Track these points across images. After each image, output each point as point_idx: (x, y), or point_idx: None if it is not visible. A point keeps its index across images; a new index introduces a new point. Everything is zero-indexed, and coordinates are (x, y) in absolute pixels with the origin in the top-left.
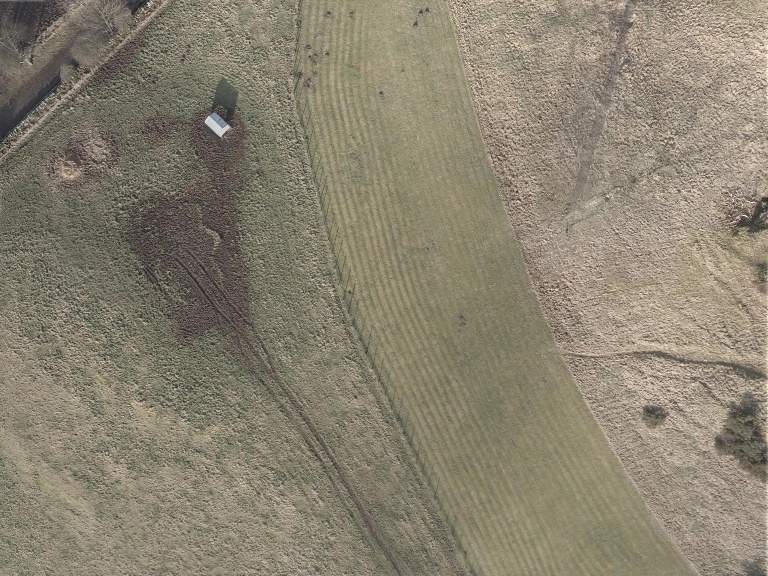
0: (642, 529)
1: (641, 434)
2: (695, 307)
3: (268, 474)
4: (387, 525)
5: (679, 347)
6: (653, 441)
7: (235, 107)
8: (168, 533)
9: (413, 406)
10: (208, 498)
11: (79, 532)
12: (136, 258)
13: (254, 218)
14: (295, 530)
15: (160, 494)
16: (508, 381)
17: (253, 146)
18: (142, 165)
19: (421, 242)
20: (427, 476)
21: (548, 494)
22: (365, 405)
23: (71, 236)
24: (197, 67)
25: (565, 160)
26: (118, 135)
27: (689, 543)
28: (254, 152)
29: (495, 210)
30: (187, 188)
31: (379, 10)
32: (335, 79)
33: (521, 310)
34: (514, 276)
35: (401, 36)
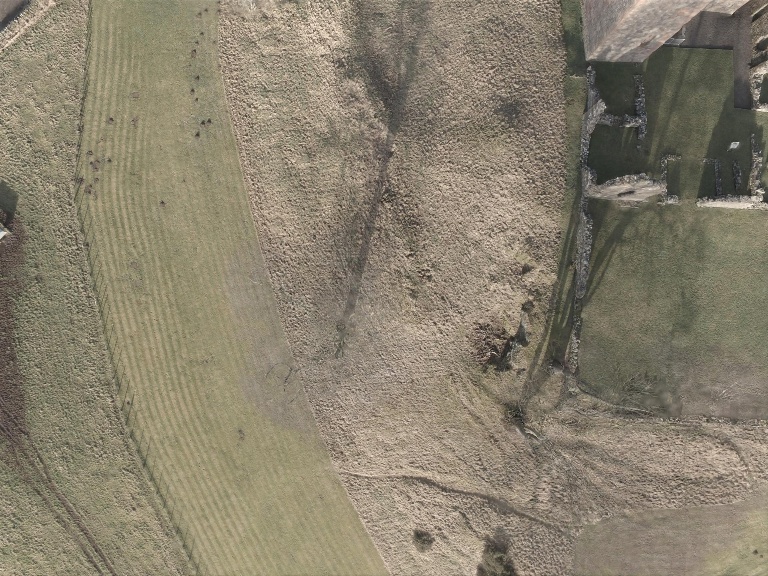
0: None
1: (413, 556)
2: (453, 438)
3: None
4: None
5: (441, 475)
6: (424, 563)
7: (15, 211)
8: None
9: (193, 519)
10: None
11: None
12: None
13: (31, 325)
14: None
15: None
16: (287, 497)
17: (32, 252)
18: None
19: (200, 355)
20: None
21: None
22: (144, 517)
23: None
24: None
25: (337, 281)
26: None
27: None
28: (33, 258)
29: (272, 326)
30: None
31: (162, 119)
32: (117, 186)
33: (298, 427)
34: (291, 393)
35: (183, 146)
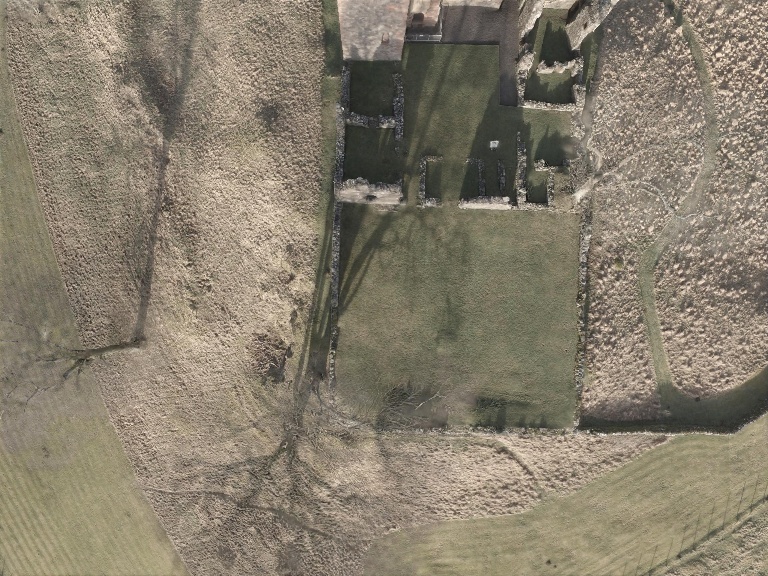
0: None
1: (221, 572)
2: (242, 452)
3: None
4: None
5: (236, 490)
6: None
7: None
8: None
9: (2, 540)
10: None
11: None
12: None
13: None
14: None
15: None
16: (95, 515)
17: None
18: None
19: (0, 371)
20: None
21: None
22: None
23: None
24: None
25: (129, 293)
26: None
27: None
28: None
29: (71, 340)
30: None
31: None
32: None
33: (101, 443)
34: (92, 408)
35: None
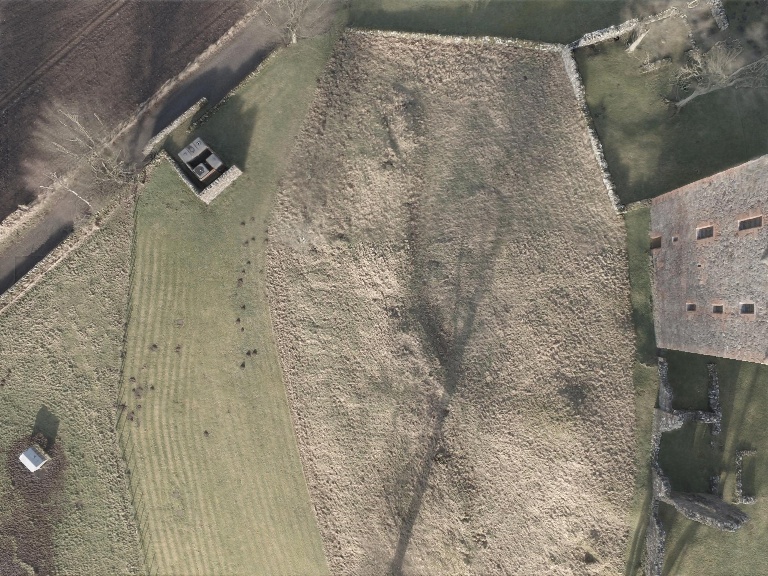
0: None
1: None
2: None
3: None
4: None
5: None
6: None
7: (55, 436)
8: None
9: None
10: None
11: None
12: None
13: (71, 553)
14: None
15: None
16: None
17: (73, 478)
18: None
19: None
20: None
21: None
22: None
23: None
24: (17, 393)
25: (386, 527)
26: None
27: None
28: (74, 484)
29: (318, 564)
30: (2, 519)
31: (206, 347)
32: (159, 414)
33: None
34: None
35: (228, 376)
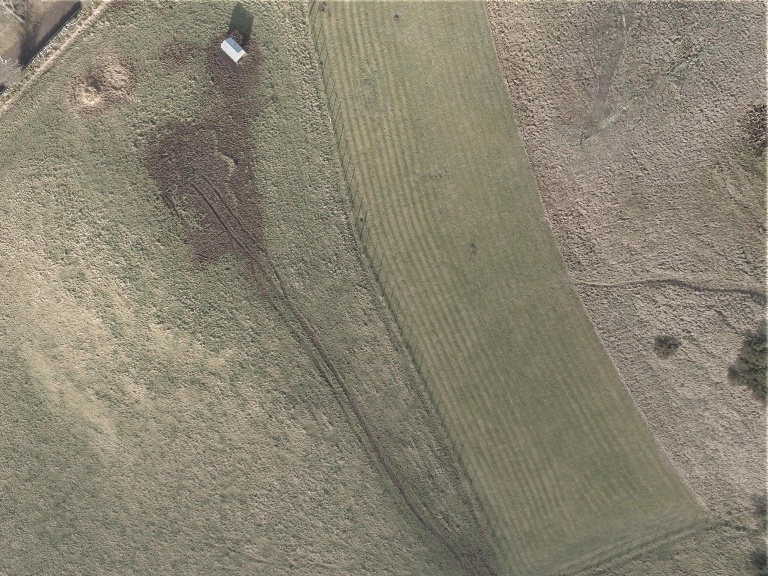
0: (649, 461)
1: (652, 365)
2: (713, 232)
3: (280, 398)
4: (395, 451)
5: (695, 275)
6: (664, 372)
7: (250, 32)
8: (184, 452)
9: (422, 334)
10: (222, 420)
11: (101, 449)
12: (154, 183)
13: (268, 145)
14: (305, 453)
15: (177, 415)
16: (518, 311)
17: (268, 72)
18: (160, 91)
19: (434, 169)
20: (435, 404)
21: (555, 424)
22: (375, 332)
23: (92, 161)
24: None
25: (583, 82)
26: (136, 61)
27: (697, 476)
28: (269, 78)
29: (510, 136)
30: (203, 114)
31: None
32: (350, 3)
33: (533, 239)
34: (527, 204)
35: None
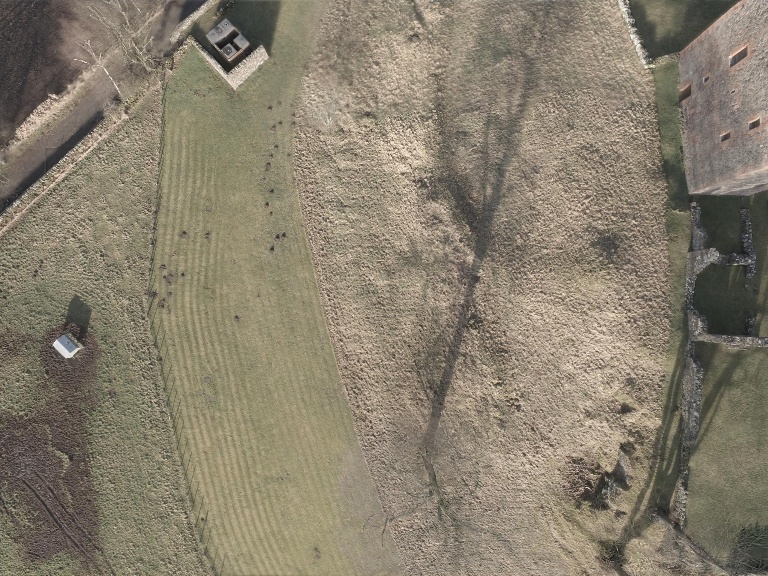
0: None
1: None
2: (542, 570)
3: None
4: None
5: None
6: None
7: (88, 325)
8: None
9: None
10: None
11: None
12: None
13: (105, 440)
14: None
15: None
16: None
17: (105, 366)
18: None
19: (275, 472)
20: None
21: None
22: None
23: None
24: (50, 283)
25: (417, 402)
26: None
27: None
28: (106, 372)
29: (350, 444)
30: (36, 408)
31: (235, 232)
32: (190, 301)
33: (376, 547)
34: (369, 512)
35: (257, 260)
